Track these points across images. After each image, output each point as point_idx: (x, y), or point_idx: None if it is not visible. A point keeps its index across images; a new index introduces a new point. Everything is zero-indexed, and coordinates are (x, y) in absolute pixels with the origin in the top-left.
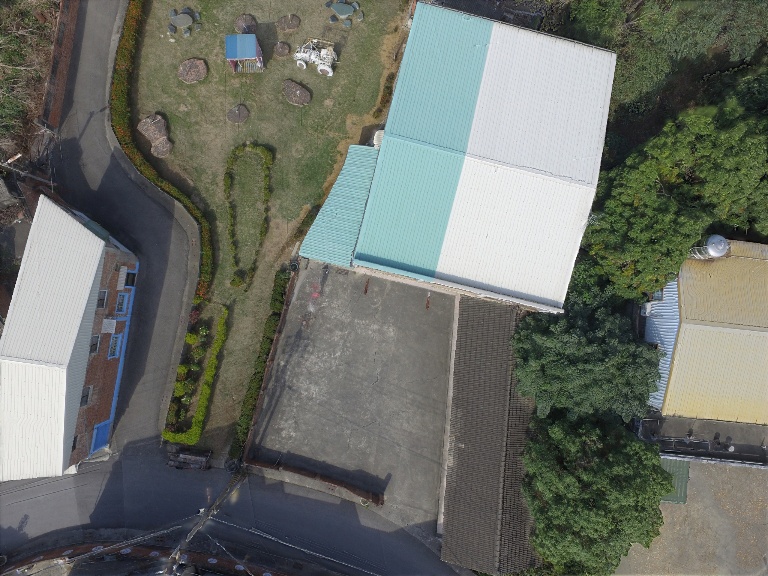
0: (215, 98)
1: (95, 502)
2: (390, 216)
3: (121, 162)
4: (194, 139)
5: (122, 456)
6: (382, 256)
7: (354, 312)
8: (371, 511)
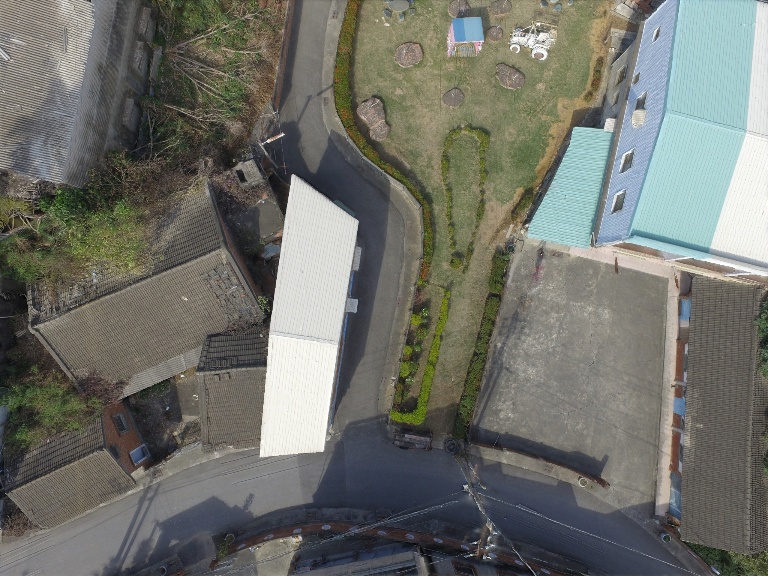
0: (430, 82)
1: (318, 482)
2: (668, 193)
3: (338, 145)
4: (410, 122)
5: (344, 436)
6: (657, 233)
7: (569, 294)
8: (588, 493)
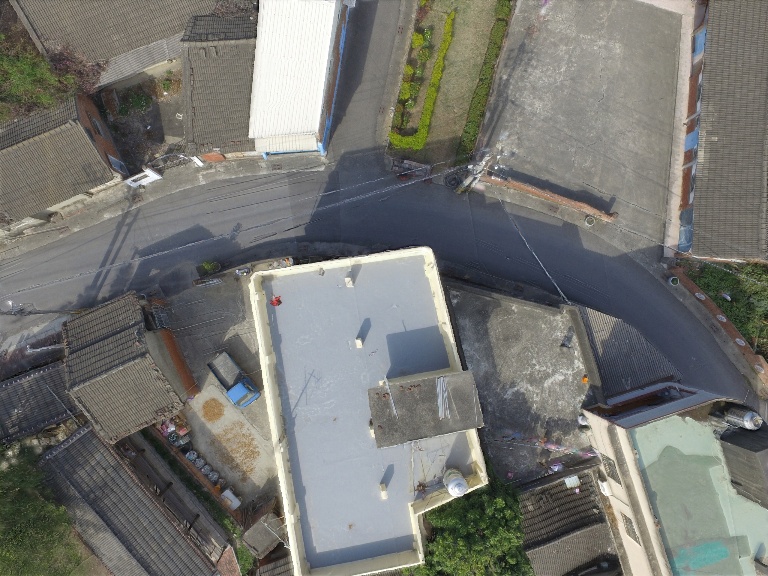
0: None
1: (311, 213)
2: None
3: None
4: None
5: (339, 166)
6: None
7: (579, 27)
8: (594, 235)
